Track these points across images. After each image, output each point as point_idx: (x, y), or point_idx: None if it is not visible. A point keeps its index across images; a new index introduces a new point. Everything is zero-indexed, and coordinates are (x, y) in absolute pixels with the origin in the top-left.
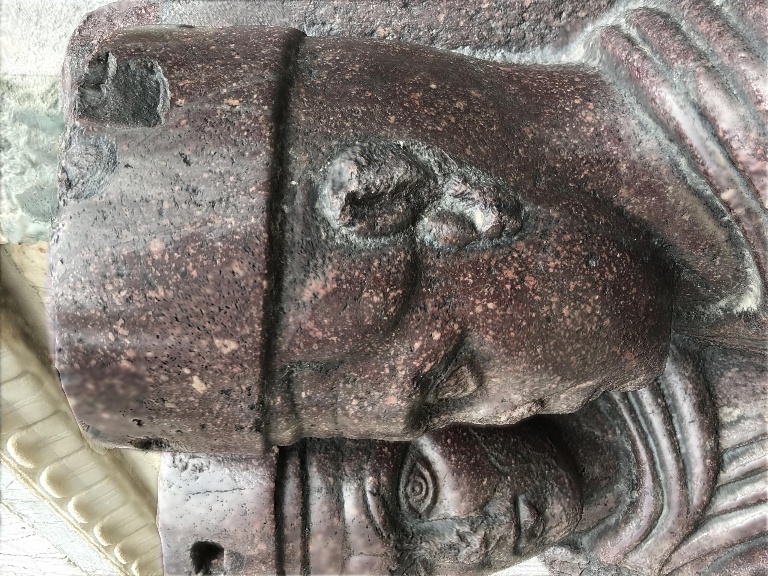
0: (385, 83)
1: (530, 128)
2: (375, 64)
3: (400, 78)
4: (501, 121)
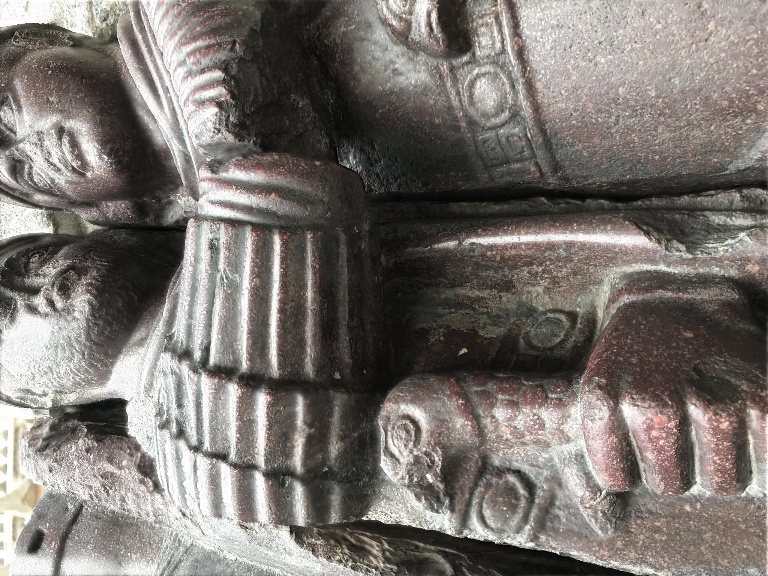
0: None
1: None
2: None
3: None
4: None
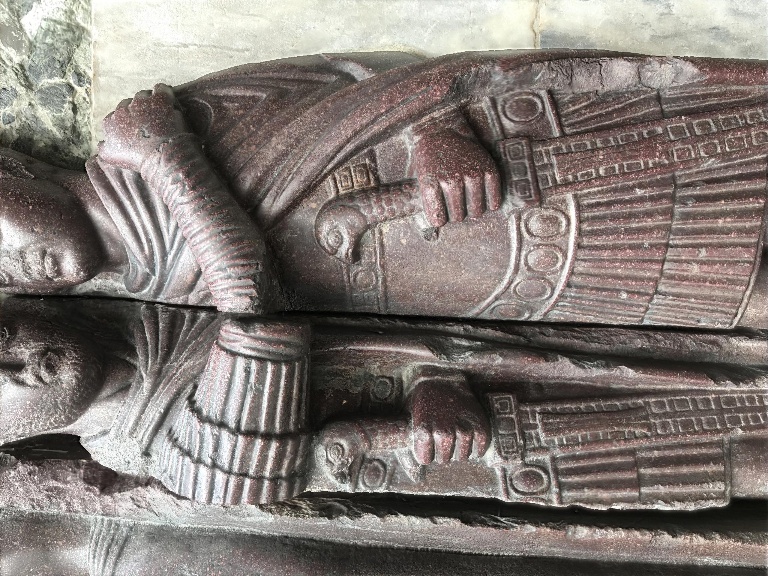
0: (16, 575)
1: (64, 572)
2: (13, 566)
3: (21, 571)
4: (54, 574)
